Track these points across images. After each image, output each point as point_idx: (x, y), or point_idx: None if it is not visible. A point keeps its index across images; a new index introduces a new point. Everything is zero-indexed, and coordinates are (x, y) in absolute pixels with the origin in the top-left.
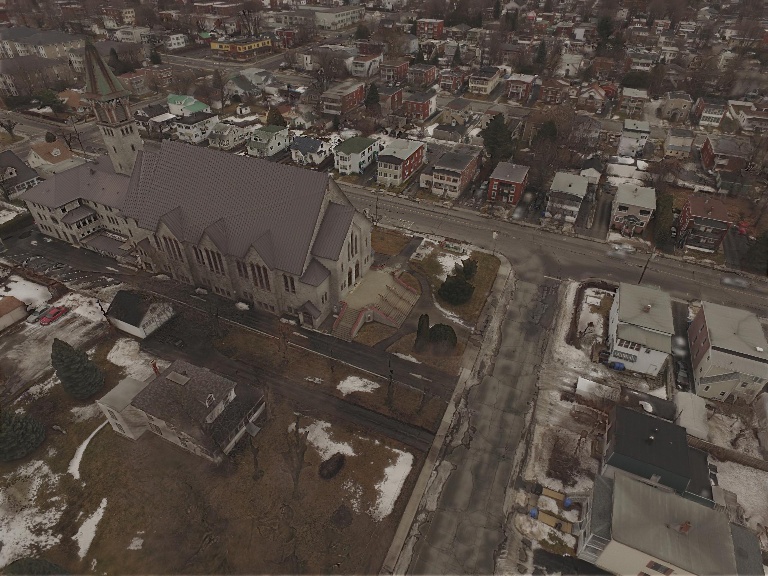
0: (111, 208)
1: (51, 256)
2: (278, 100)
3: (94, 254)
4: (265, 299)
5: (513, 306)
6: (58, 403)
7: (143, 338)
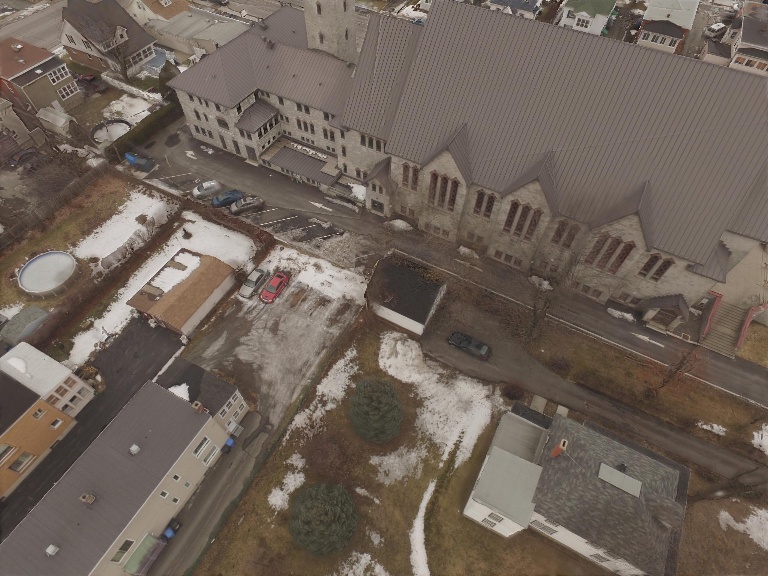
0: (309, 108)
1: (224, 179)
2: None
3: (283, 178)
4: (592, 281)
5: None
6: (346, 446)
7: (420, 334)
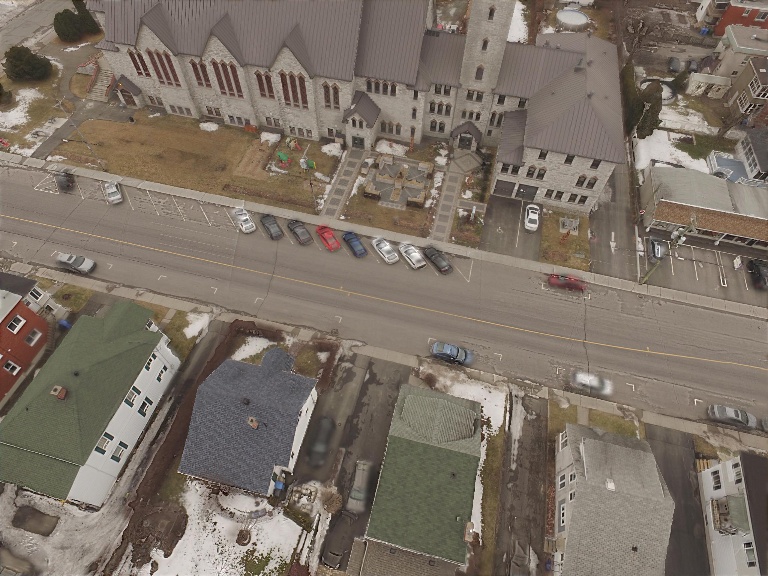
0: None
1: None
2: None
3: None
4: None
5: None
6: None
7: None
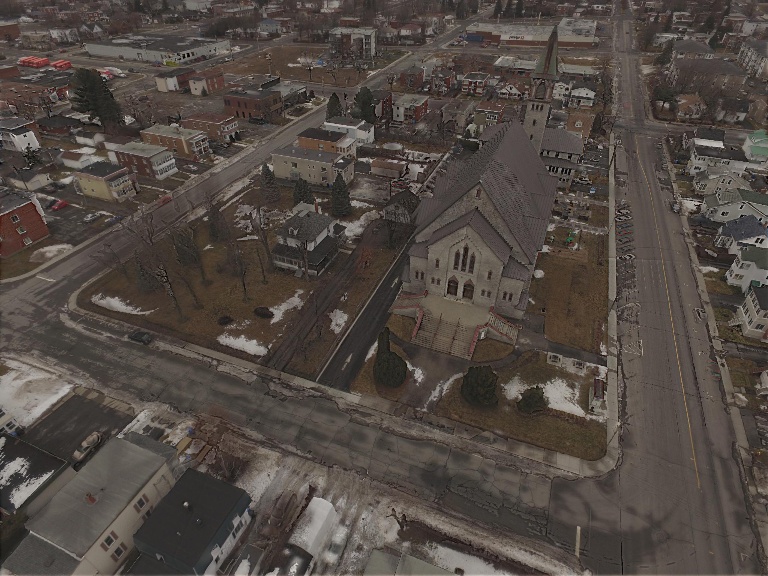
0: None
1: None
2: None
3: None
4: None
5: (480, 462)
6: None
7: (384, 218)
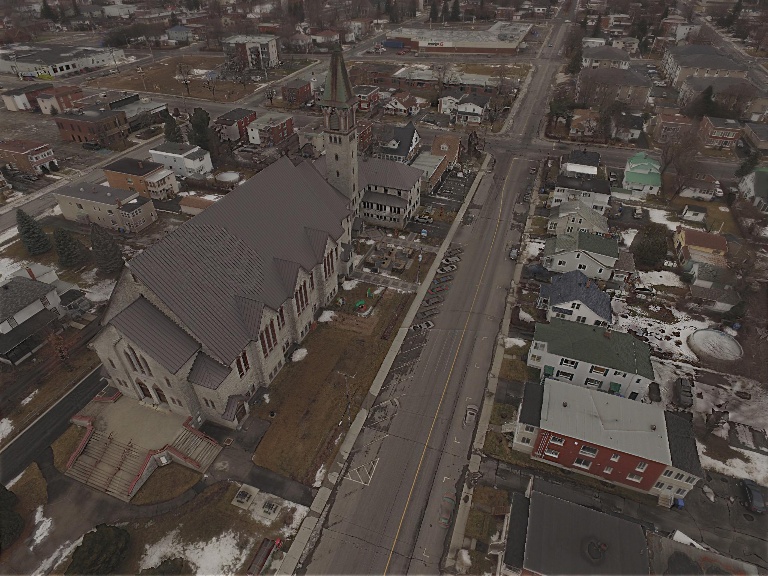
0: None
1: None
2: (767, 232)
3: None
4: None
5: None
6: None
7: None
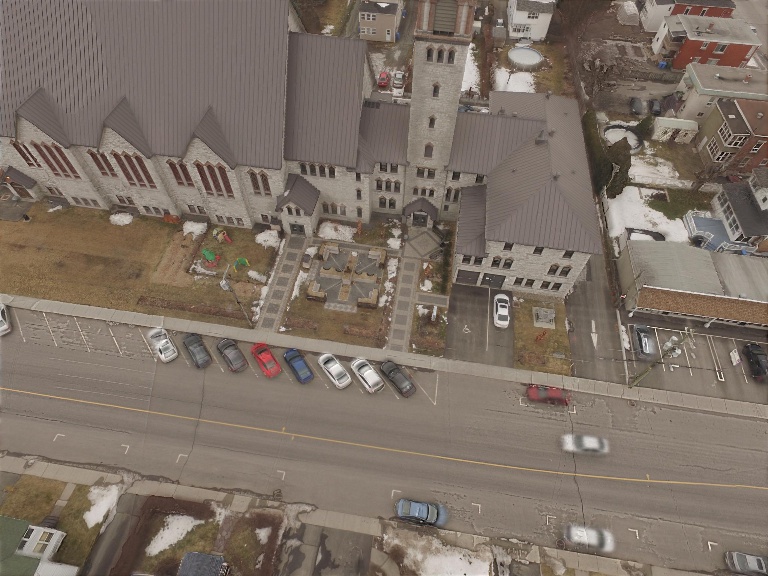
0: None
1: None
2: None
3: None
4: None
5: None
6: None
7: None
